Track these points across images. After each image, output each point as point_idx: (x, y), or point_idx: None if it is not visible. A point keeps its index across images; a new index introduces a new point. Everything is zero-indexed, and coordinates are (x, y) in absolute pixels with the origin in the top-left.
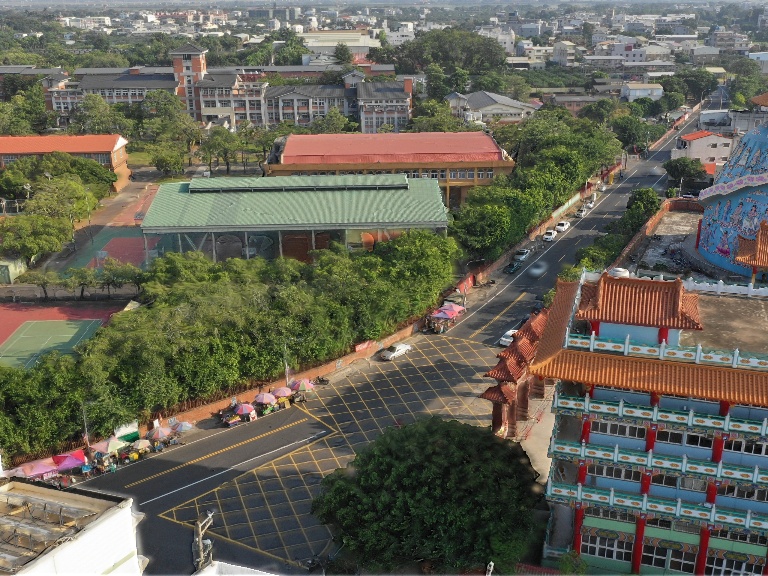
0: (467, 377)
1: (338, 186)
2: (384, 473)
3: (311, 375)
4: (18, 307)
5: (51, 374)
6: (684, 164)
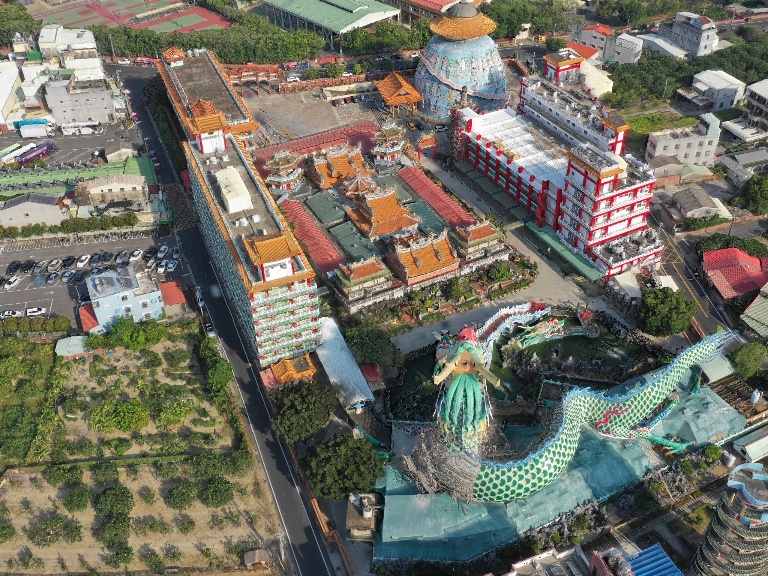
0: None
1: (333, 3)
2: None
3: (229, 66)
4: (223, 18)
5: (153, 37)
6: (550, 42)
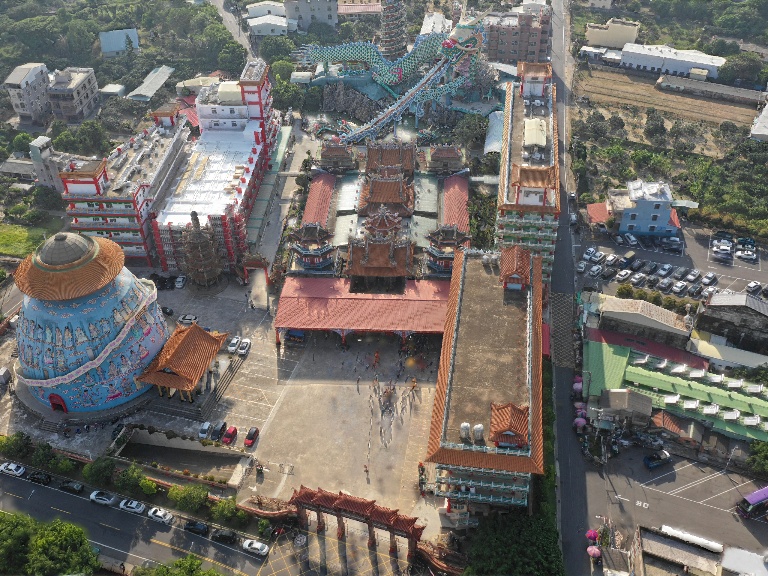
0: (320, 575)
1: None
2: (539, 567)
3: None
4: None
5: None
6: None
